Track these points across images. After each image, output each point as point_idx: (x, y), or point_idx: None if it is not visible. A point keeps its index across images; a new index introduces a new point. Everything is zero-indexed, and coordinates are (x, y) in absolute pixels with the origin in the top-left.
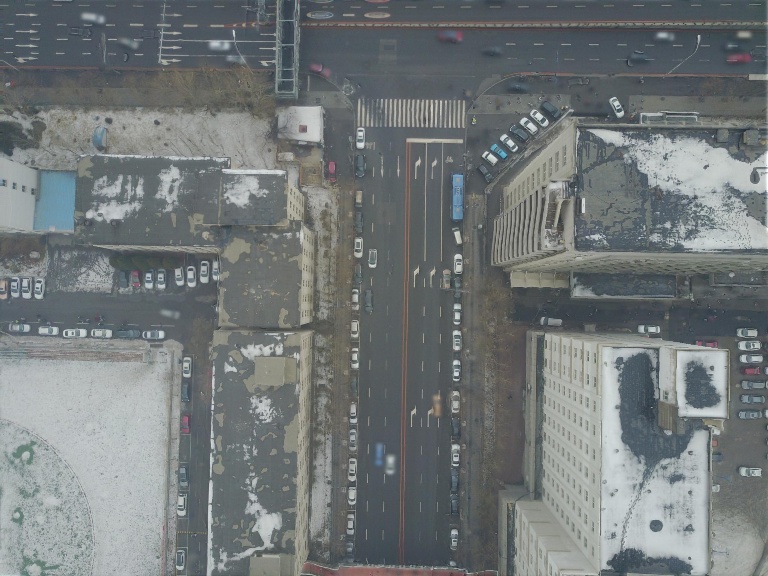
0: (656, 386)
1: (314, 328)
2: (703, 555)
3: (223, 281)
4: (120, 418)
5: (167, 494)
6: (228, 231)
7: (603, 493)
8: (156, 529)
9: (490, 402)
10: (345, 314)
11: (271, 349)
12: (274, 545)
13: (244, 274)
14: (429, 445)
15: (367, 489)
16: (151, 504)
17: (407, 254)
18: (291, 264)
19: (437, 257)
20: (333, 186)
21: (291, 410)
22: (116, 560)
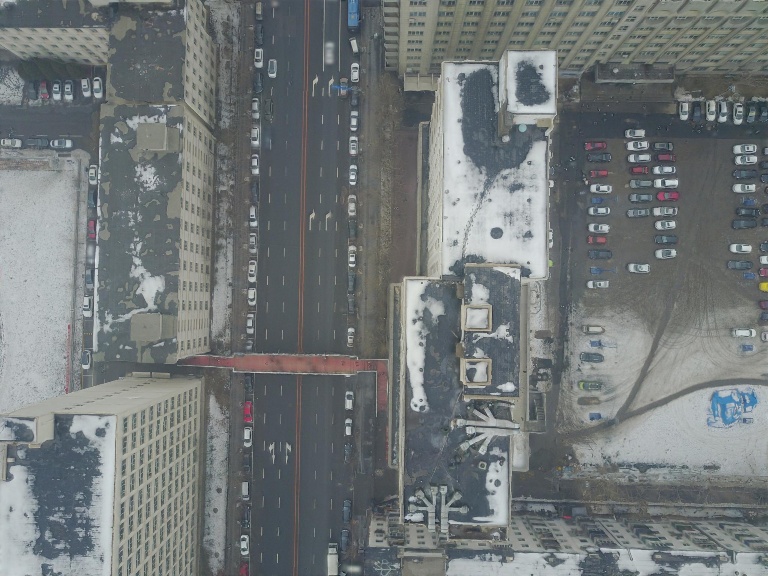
0: (496, 100)
1: (216, 136)
2: (541, 259)
3: (110, 57)
4: (29, 224)
5: (74, 296)
6: (115, 10)
7: (445, 202)
8: (63, 330)
9: (386, 205)
10: (246, 122)
11: (155, 120)
12: (157, 307)
13: (130, 50)
14: (327, 248)
15: (267, 291)
16: (58, 306)
17: (306, 65)
18: (175, 40)
19: (335, 67)
20: (235, 0)
21: (174, 178)
22: (25, 361)
